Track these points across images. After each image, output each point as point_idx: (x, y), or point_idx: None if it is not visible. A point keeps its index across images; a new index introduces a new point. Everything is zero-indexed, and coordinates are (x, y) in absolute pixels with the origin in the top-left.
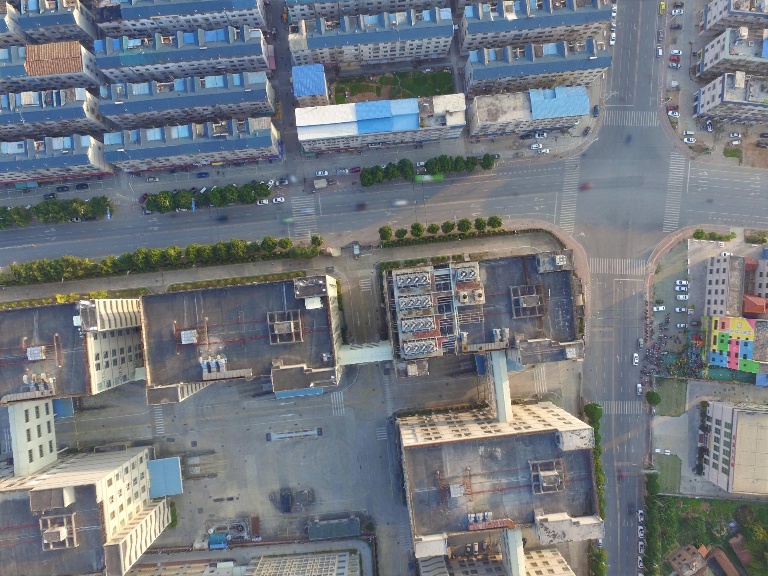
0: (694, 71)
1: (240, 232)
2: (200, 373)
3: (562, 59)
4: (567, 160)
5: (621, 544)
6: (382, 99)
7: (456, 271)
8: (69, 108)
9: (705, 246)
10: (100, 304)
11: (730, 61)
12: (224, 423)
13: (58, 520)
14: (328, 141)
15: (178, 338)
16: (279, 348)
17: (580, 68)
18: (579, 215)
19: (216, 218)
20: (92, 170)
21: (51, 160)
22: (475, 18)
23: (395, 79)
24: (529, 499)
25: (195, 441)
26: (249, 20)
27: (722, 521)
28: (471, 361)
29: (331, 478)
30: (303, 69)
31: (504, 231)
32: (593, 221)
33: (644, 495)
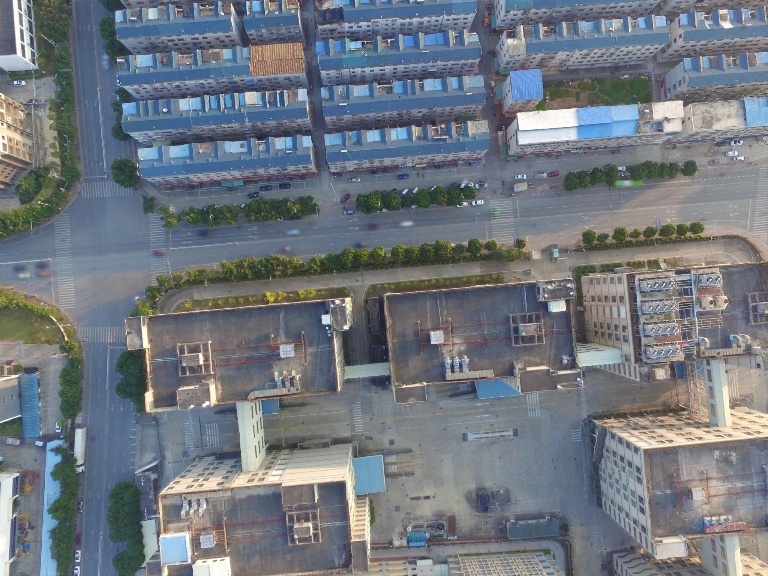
0: None
1: (439, 234)
2: (442, 373)
3: None
4: (761, 168)
5: None
6: (581, 104)
7: (698, 277)
8: (293, 109)
9: None
10: (346, 303)
11: None
12: (421, 422)
13: (302, 515)
14: (543, 145)
15: (423, 338)
16: (519, 350)
17: None
18: None
19: (416, 219)
20: (303, 170)
21: (275, 160)
22: (690, 26)
23: (593, 84)
24: (763, 503)
25: (393, 440)
26: (459, 24)
27: None
28: None
29: (526, 479)
30: (522, 74)
31: (700, 237)
32: None
33: None
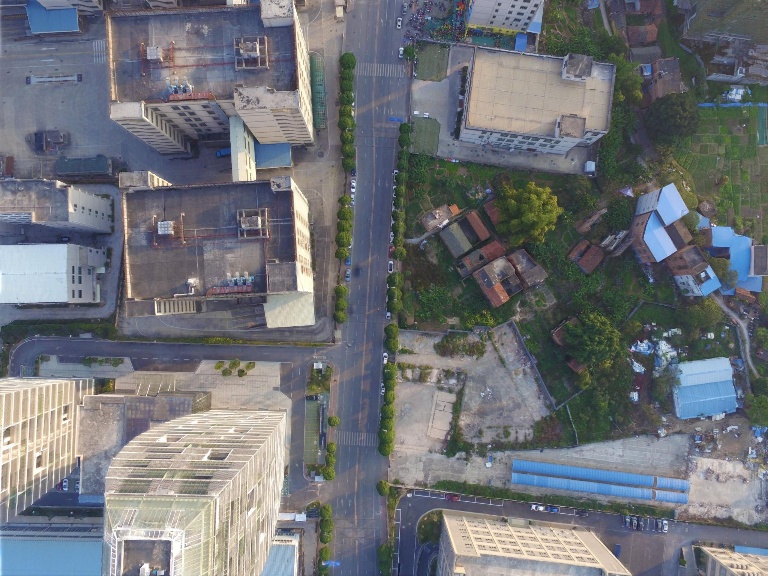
0: None
1: None
2: None
3: None
4: None
5: (375, 203)
6: None
7: None
8: None
9: None
10: None
11: None
12: None
13: None
14: None
15: None
16: None
17: None
18: None
19: None
20: None
21: None
22: None
23: None
24: (233, 77)
25: None
26: None
27: (478, 185)
28: None
29: (88, 123)
30: None
31: None
32: None
33: None
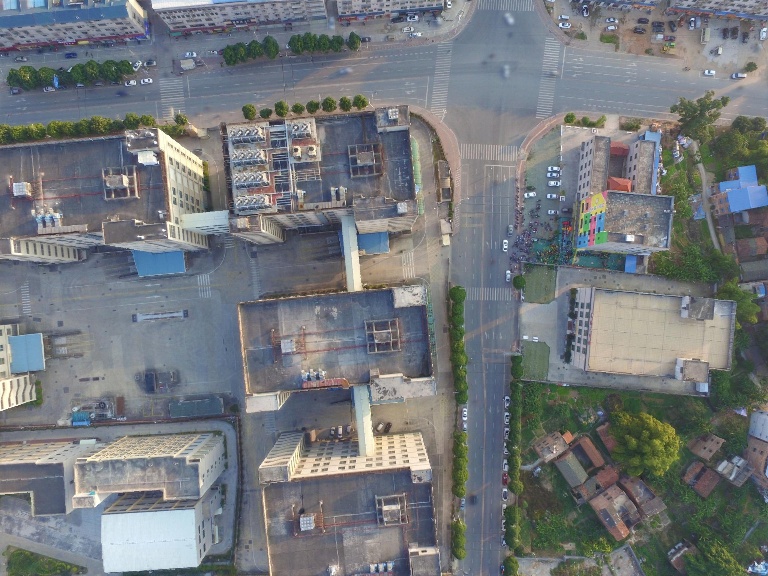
0: None
1: (108, 113)
2: (36, 228)
3: None
4: (439, 44)
5: (487, 430)
6: None
7: None
8: None
9: (579, 133)
10: None
11: None
12: (90, 304)
13: None
14: (186, 13)
15: None
16: (115, 205)
17: None
18: (451, 100)
19: (84, 99)
20: None
21: None
22: None
23: None
24: (365, 359)
25: (61, 321)
26: None
27: (590, 409)
28: (339, 246)
29: (197, 360)
30: None
31: None
32: (465, 106)
33: None
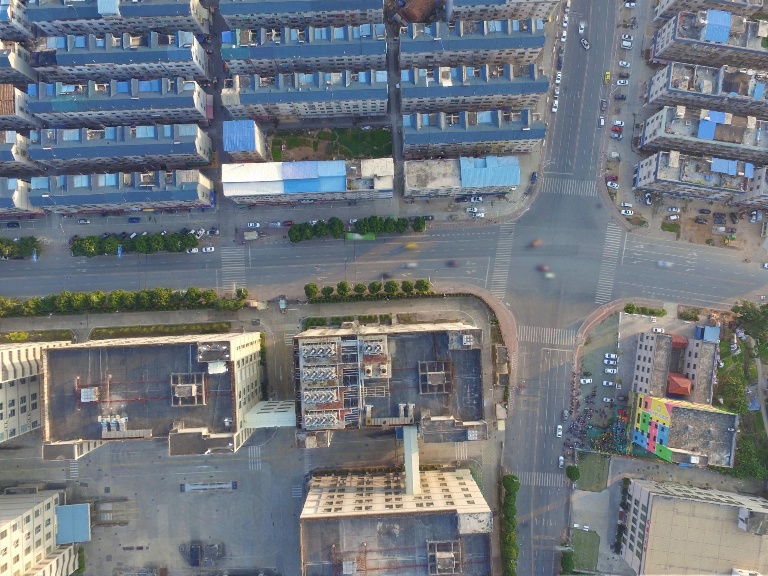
0: (636, 143)
1: (168, 279)
2: (100, 430)
3: (495, 129)
4: (502, 225)
5: None
6: (319, 154)
7: (363, 343)
8: None
9: (637, 320)
10: (4, 355)
11: (667, 138)
12: (139, 471)
13: None
14: (255, 197)
15: (79, 394)
16: (181, 410)
17: (513, 138)
18: (511, 281)
19: (145, 264)
20: (21, 211)
21: None
22: (410, 82)
23: (333, 134)
24: None
25: (108, 487)
26: (187, 70)
27: None
28: None
29: (243, 533)
30: (234, 124)
31: (433, 294)
32: (525, 288)
33: (560, 570)
